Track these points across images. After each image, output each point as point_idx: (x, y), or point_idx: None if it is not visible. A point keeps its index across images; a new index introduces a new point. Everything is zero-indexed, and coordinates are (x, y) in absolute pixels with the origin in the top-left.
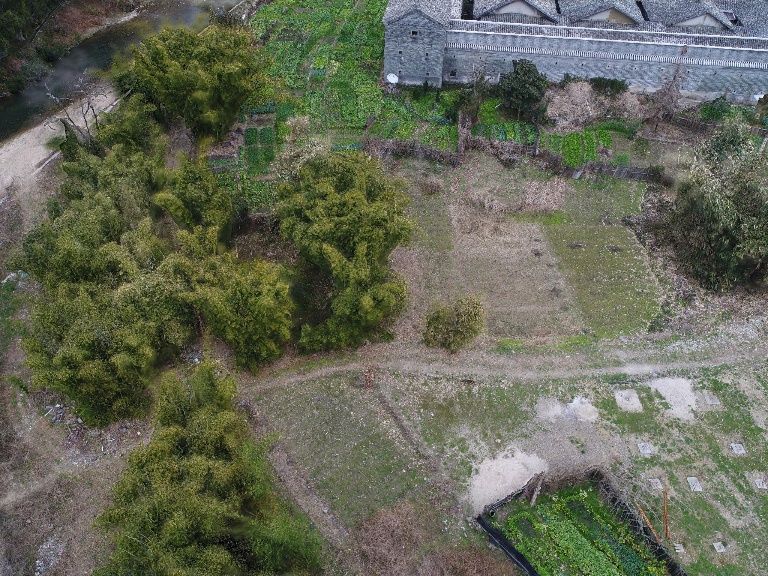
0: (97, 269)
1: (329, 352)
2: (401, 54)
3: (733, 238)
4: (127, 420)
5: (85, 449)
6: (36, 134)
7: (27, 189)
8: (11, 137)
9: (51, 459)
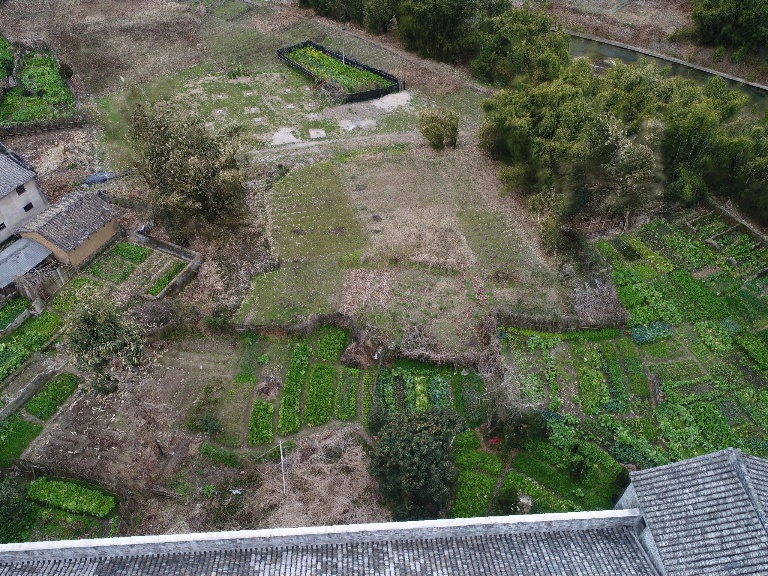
0: None
1: None
2: None
3: None
4: None
5: None
6: None
7: None
8: None
9: None
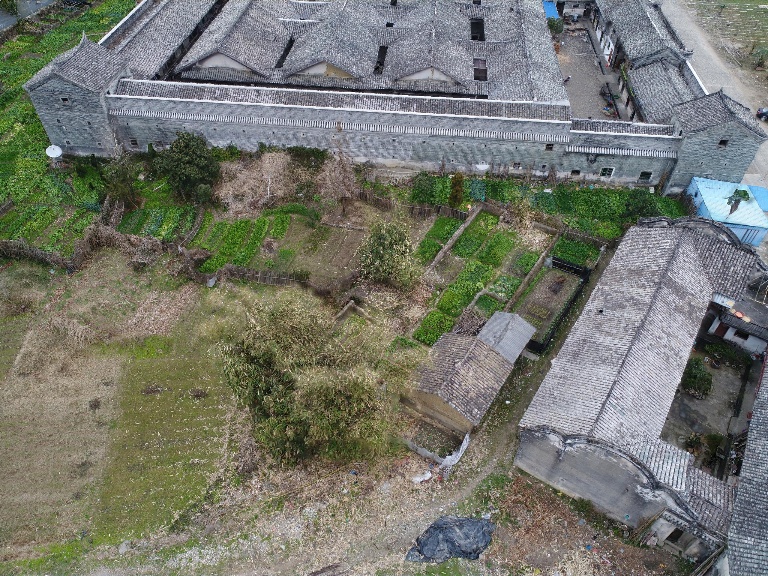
0: None
1: None
2: (60, 123)
3: (264, 410)
4: None
5: None
6: None
7: None
8: None
9: None
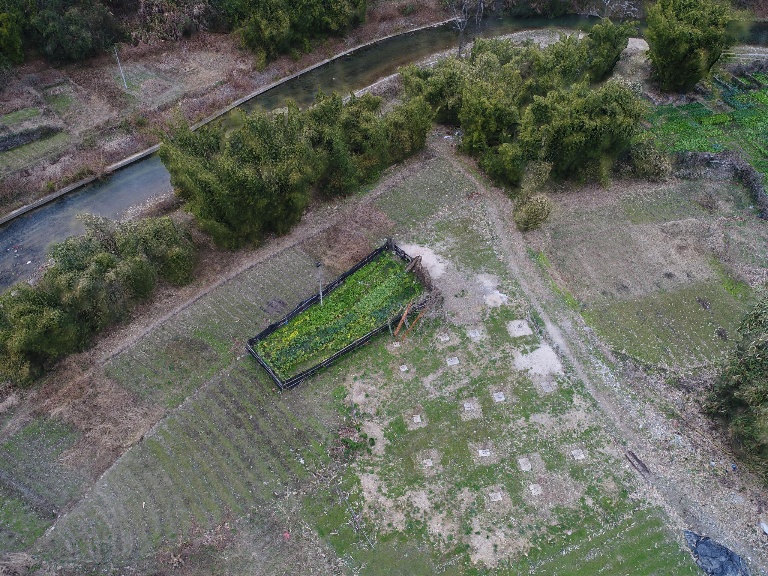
0: None
1: (486, 175)
2: None
3: None
4: None
5: None
6: None
7: None
8: None
9: None
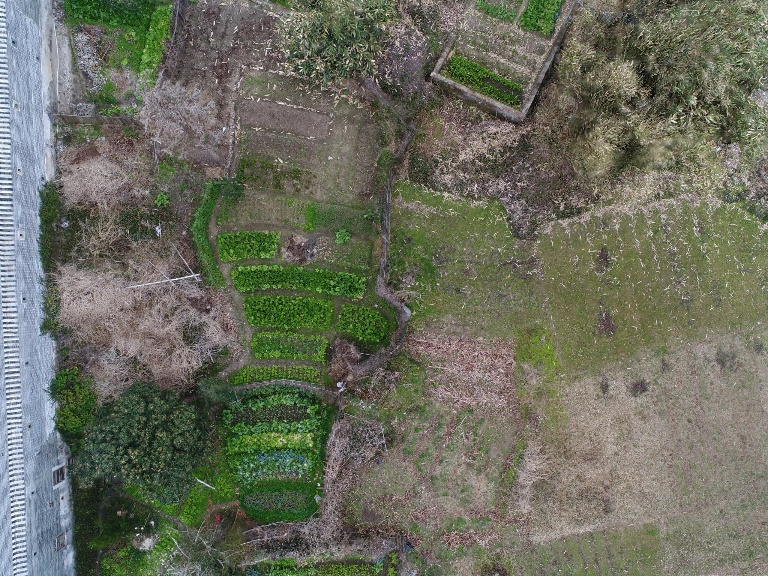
0: None
1: None
2: None
3: None
4: None
5: None
6: None
7: None
8: None
9: None
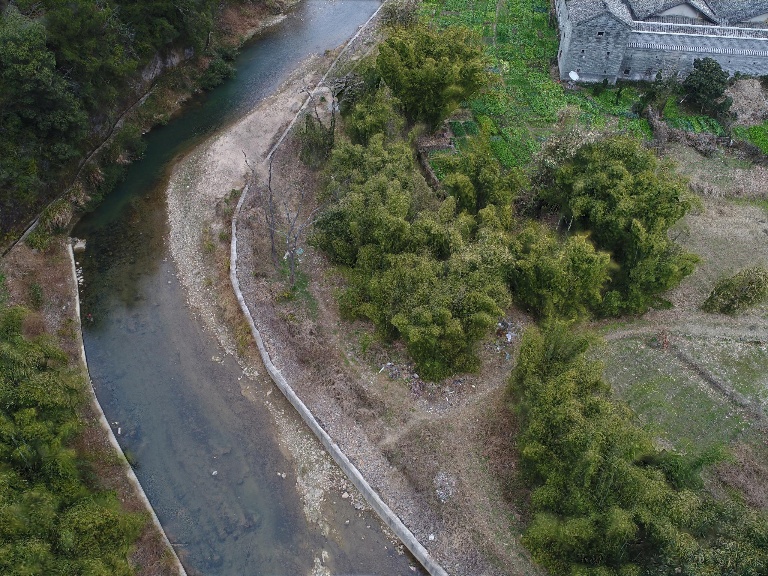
0: (416, 242)
1: (620, 317)
2: (583, 53)
3: None
4: (458, 375)
5: (432, 400)
6: (245, 127)
7: (268, 176)
8: (221, 130)
9: (406, 408)
